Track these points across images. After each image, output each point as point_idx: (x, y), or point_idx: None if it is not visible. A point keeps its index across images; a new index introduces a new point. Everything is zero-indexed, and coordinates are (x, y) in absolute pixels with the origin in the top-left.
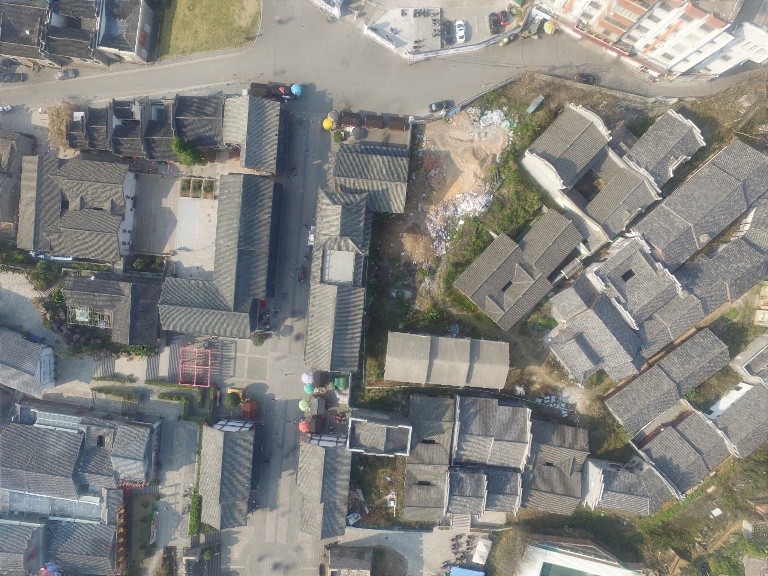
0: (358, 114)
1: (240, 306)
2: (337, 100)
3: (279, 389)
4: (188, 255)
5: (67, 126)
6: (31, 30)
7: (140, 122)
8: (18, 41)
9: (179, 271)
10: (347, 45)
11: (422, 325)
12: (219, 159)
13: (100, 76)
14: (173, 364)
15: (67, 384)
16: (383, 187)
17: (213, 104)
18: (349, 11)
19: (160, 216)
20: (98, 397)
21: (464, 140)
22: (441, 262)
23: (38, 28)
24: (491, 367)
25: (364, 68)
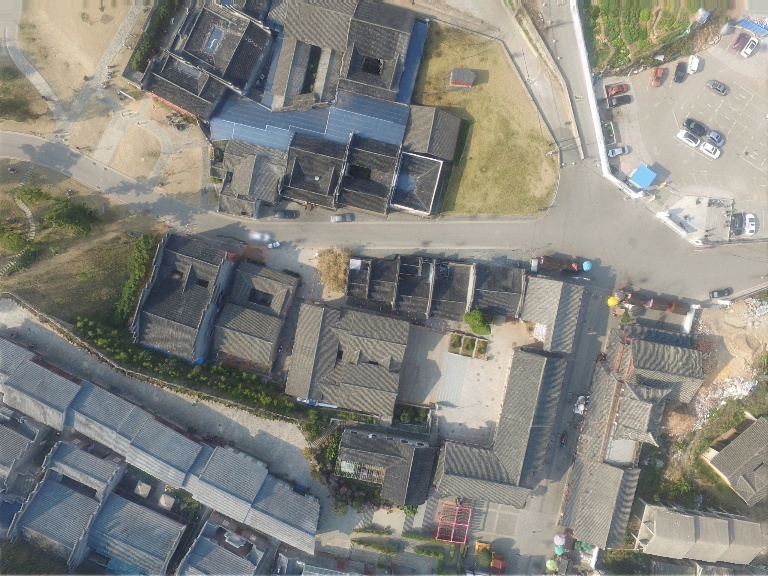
0: (645, 296)
1: (523, 480)
2: (620, 277)
3: (525, 545)
4: (452, 411)
5: (349, 277)
6: (320, 176)
7: (433, 286)
8: (307, 187)
9: (441, 426)
10: (638, 225)
11: (673, 496)
12: (495, 321)
13: (376, 223)
14: (427, 516)
15: (327, 533)
16: (679, 380)
17: (510, 277)
18: (646, 194)
19: (424, 368)
20: (356, 548)
21: (737, 326)
22: (695, 436)
23: (331, 177)
24: (745, 548)
25: (651, 249)
